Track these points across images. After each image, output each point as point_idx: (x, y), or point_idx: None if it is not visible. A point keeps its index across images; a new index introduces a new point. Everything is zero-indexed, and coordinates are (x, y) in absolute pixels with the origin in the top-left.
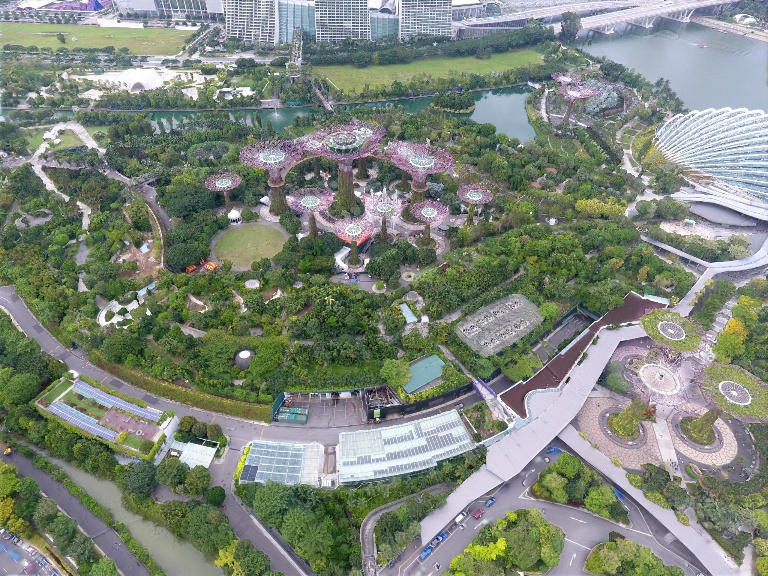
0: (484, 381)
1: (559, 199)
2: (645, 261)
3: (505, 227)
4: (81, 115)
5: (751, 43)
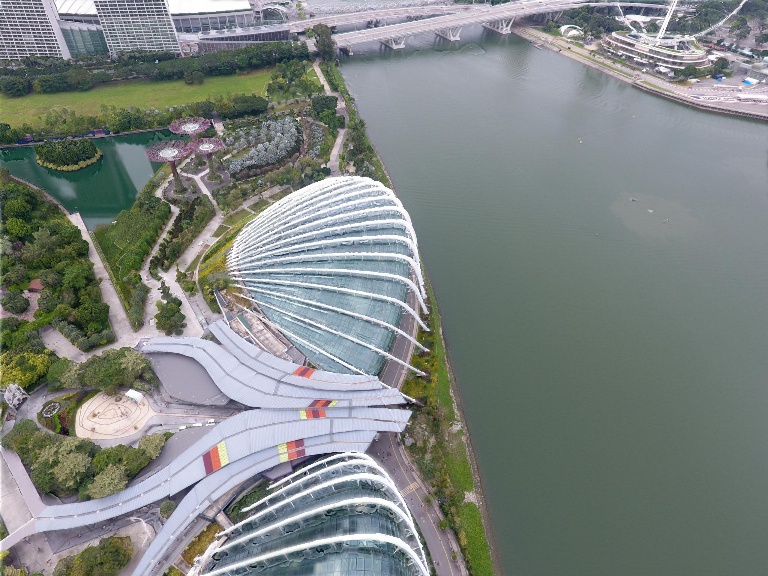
0: None
1: None
2: None
3: None
4: None
5: None
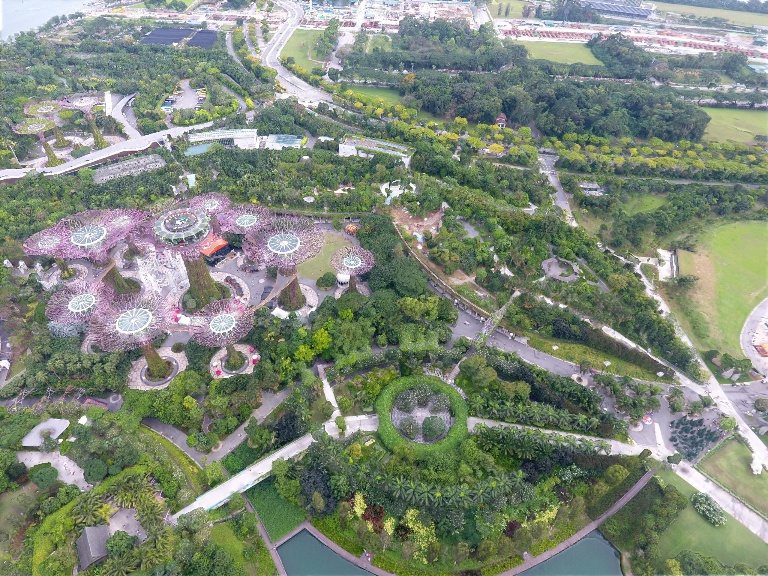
0: None
1: None
2: None
3: (32, 258)
4: None
5: None
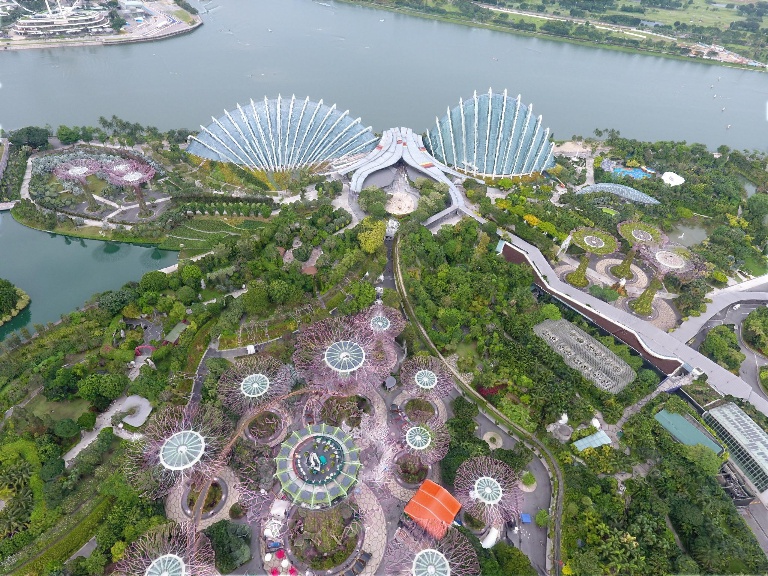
0: None
1: (359, 259)
2: None
3: None
4: None
5: (13, 55)
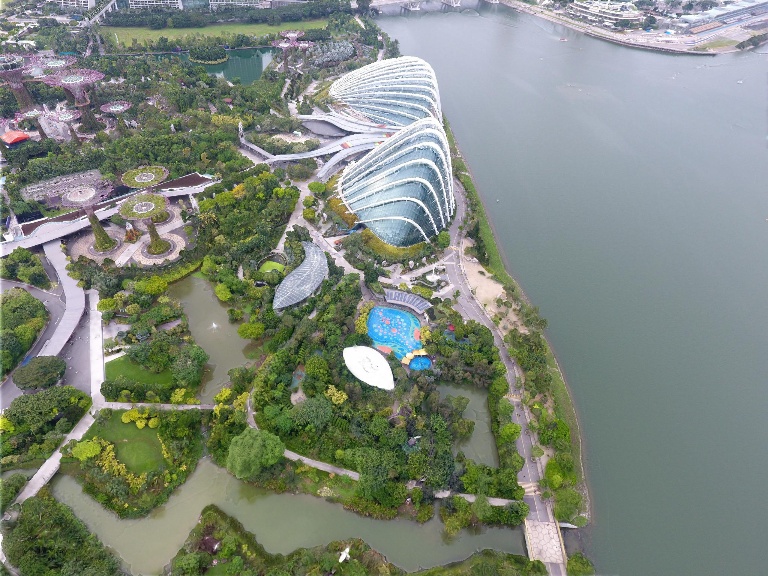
0: (17, 216)
1: None
2: (218, 152)
3: None
4: None
5: None
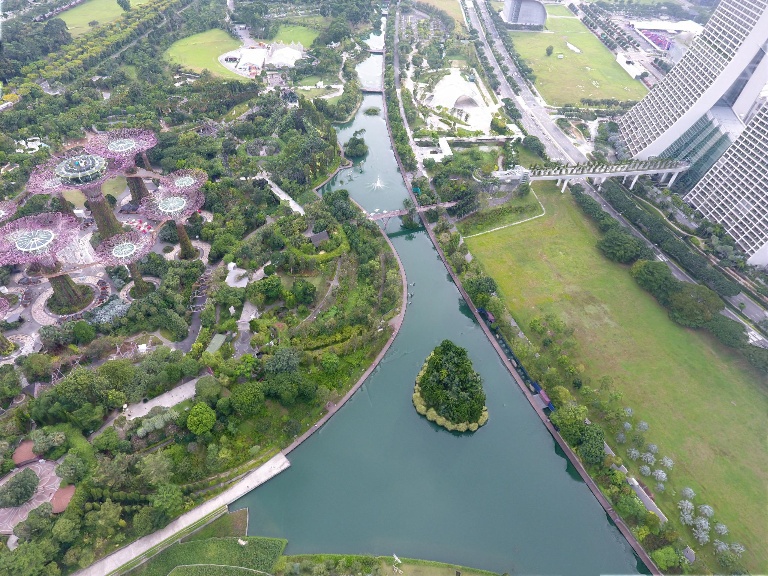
0: None
1: None
2: None
3: None
4: (344, 84)
5: None
